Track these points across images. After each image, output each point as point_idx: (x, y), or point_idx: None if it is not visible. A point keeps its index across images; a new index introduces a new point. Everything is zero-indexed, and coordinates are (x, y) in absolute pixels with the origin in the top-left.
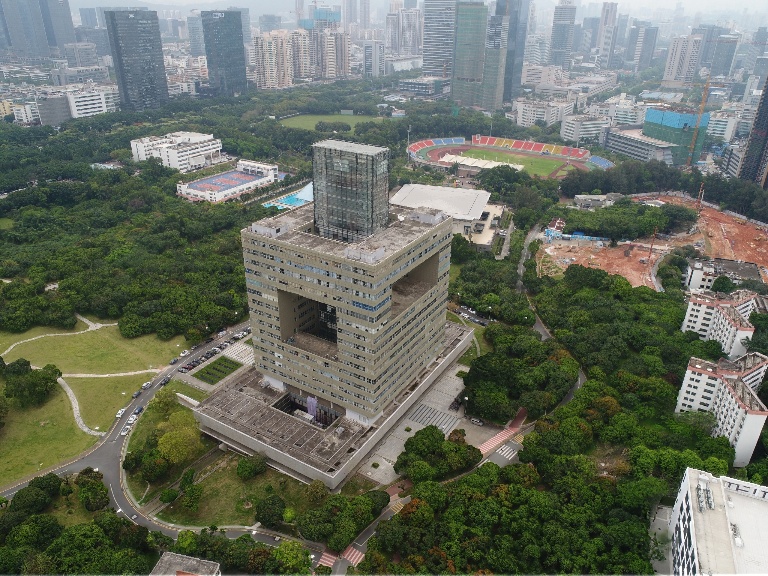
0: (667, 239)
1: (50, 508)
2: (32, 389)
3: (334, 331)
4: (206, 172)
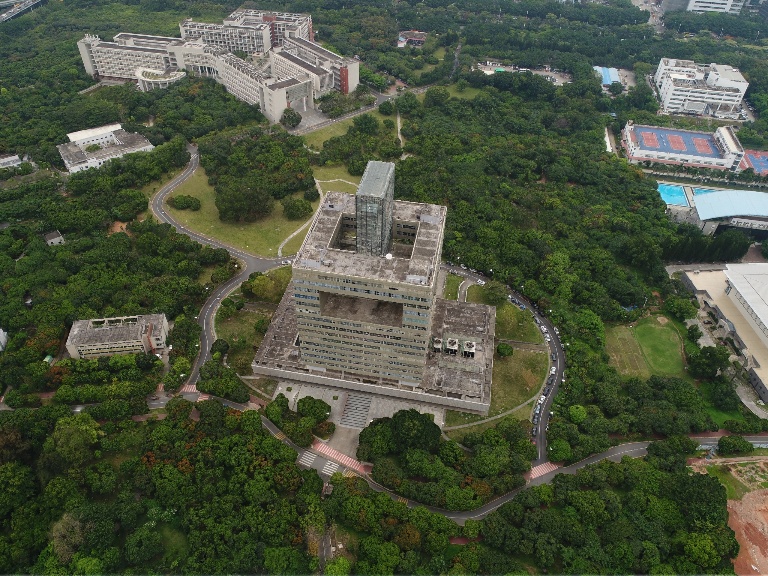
0: None
1: (213, 266)
2: (289, 209)
3: None
4: (683, 122)
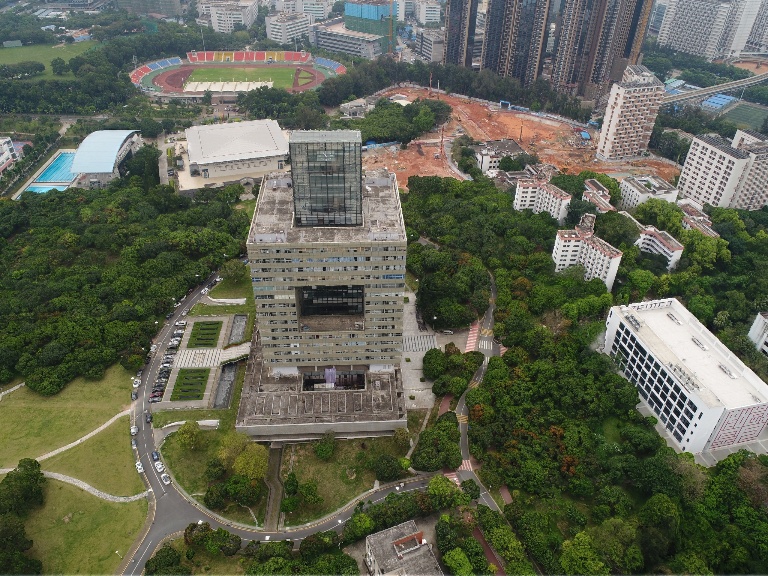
0: (437, 131)
1: None
2: (29, 493)
3: (320, 305)
4: None
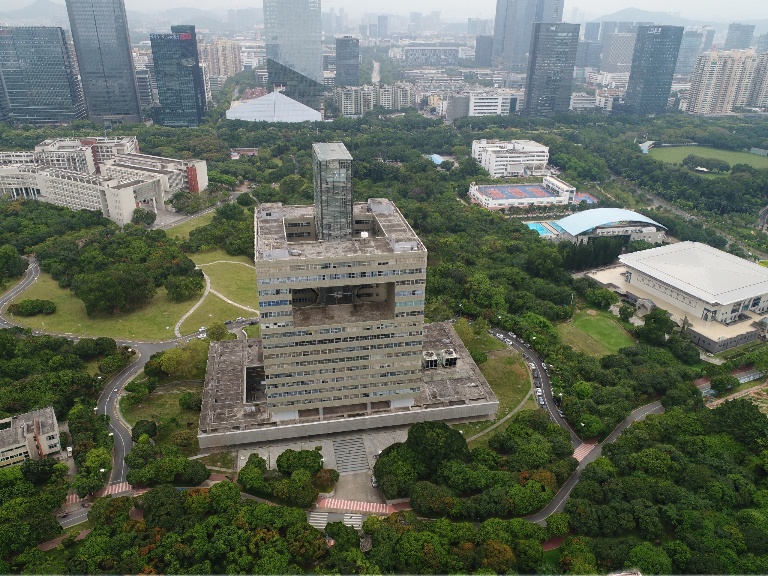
0: None
1: (96, 359)
2: (175, 288)
3: None
4: (513, 180)
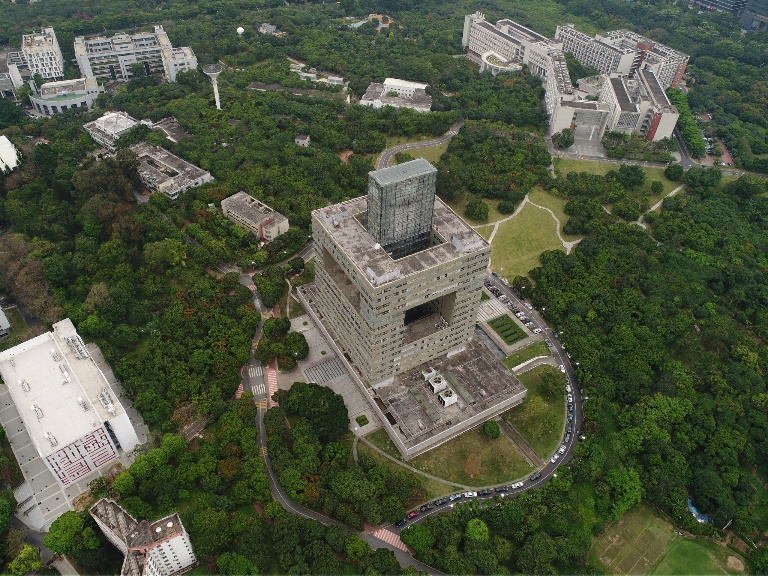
0: None
1: None
2: (468, 205)
3: None
4: None
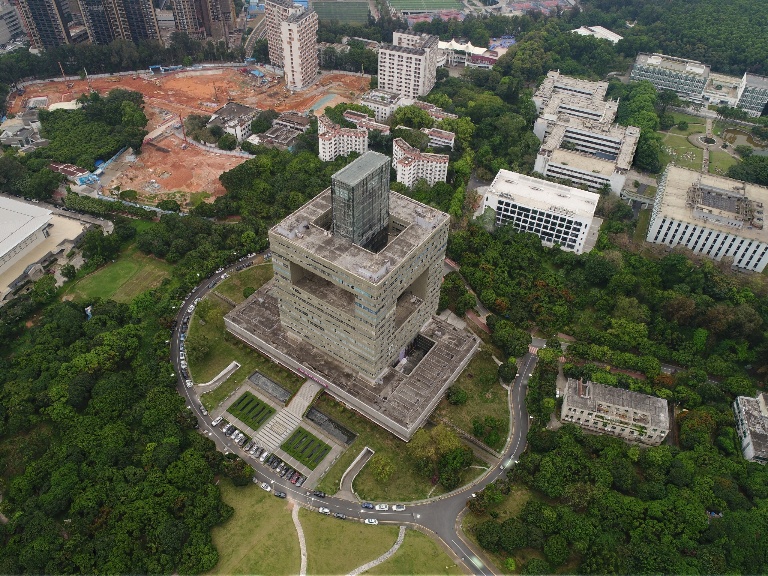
0: None
1: None
2: None
3: None
4: None
